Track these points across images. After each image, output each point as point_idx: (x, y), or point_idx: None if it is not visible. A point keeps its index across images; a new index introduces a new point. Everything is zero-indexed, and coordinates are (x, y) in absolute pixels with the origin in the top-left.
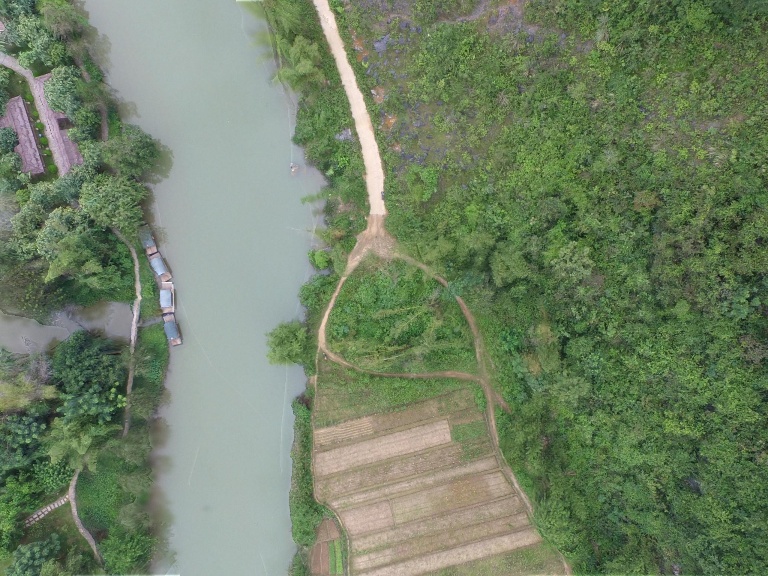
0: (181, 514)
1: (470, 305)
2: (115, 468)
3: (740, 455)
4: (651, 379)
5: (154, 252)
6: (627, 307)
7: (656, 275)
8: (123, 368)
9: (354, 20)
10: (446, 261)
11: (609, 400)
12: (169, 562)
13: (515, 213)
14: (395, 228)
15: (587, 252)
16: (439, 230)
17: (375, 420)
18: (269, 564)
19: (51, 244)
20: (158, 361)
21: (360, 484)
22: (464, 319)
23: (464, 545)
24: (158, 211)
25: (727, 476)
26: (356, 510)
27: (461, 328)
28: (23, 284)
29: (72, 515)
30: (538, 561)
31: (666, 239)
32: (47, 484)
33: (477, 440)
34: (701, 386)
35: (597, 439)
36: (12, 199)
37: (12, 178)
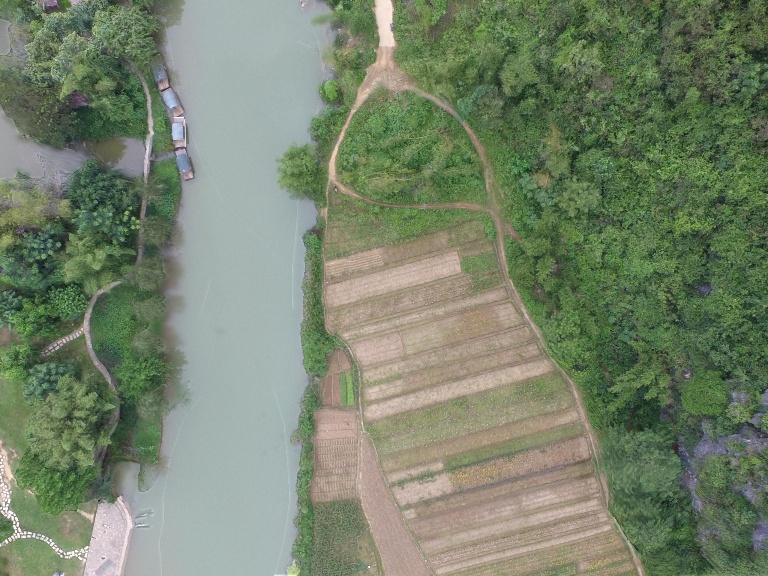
0: (194, 342)
1: (479, 134)
2: (129, 301)
3: (751, 243)
4: (661, 189)
5: (166, 87)
6: (636, 110)
7: (665, 65)
8: (136, 195)
9: None
10: (455, 80)
11: (619, 216)
12: (182, 390)
13: (524, 29)
14: (404, 58)
15: (596, 53)
16: (448, 55)
17: (385, 252)
18: (281, 397)
19: (65, 67)
20: (170, 194)
21: (371, 315)
22: (473, 149)
23: (475, 376)
24: (170, 45)
25: (738, 267)
26: (367, 341)
27: (470, 155)
28: (38, 98)
29: (87, 348)
30: (549, 391)
31: (675, 27)
32: (62, 310)
33: (487, 271)
34: (711, 180)
35: (607, 256)
36: (27, 28)
37: (26, 9)
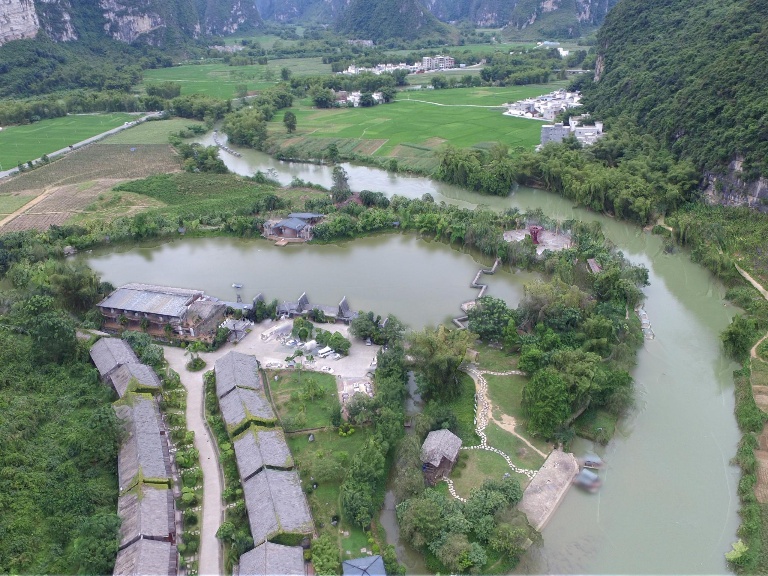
0: None
1: None
2: None
3: None
4: None
5: None
6: None
7: None
8: None
9: (760, 270)
10: None
11: None
12: (641, 405)
13: None
14: None
15: None
16: None
17: None
18: (718, 440)
19: None
20: None
21: None
22: None
23: None
24: None
25: None
26: None
27: None
28: None
29: None
30: None
31: None
32: None
33: None
34: None
35: None
36: None
37: None
